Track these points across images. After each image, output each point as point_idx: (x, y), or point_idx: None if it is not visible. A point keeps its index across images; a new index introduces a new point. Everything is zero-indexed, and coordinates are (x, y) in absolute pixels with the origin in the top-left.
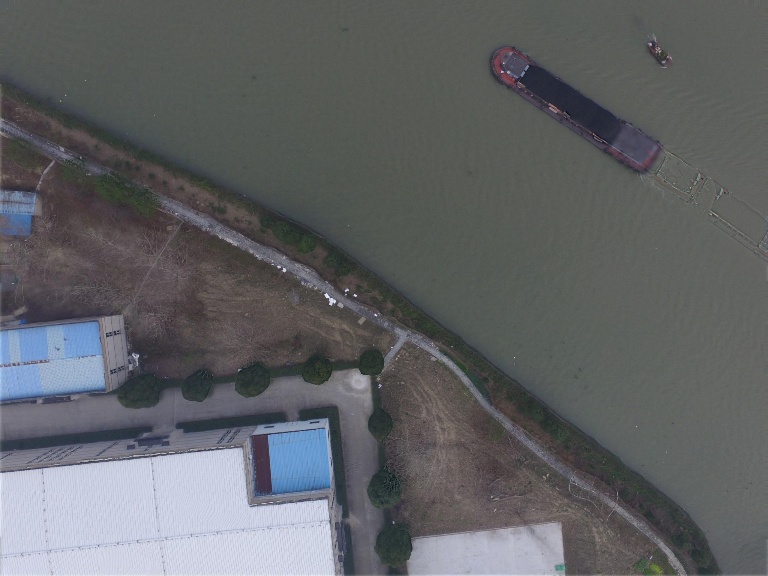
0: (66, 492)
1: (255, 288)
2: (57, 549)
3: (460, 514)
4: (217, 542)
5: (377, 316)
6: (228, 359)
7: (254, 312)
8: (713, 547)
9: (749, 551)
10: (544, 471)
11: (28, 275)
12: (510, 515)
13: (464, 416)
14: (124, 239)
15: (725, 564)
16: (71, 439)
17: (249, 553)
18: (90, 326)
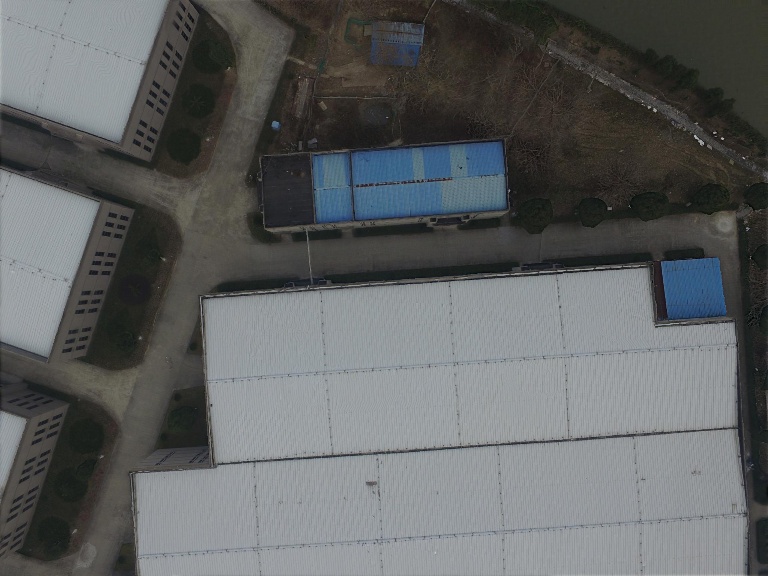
0: (472, 306)
1: (630, 125)
2: (463, 362)
3: None
4: (622, 361)
5: (745, 159)
6: (597, 197)
7: (629, 148)
8: None
9: None
10: None
11: (405, 108)
12: None
13: None
14: None
15: None
16: (441, 271)
17: (652, 375)
18: (492, 146)
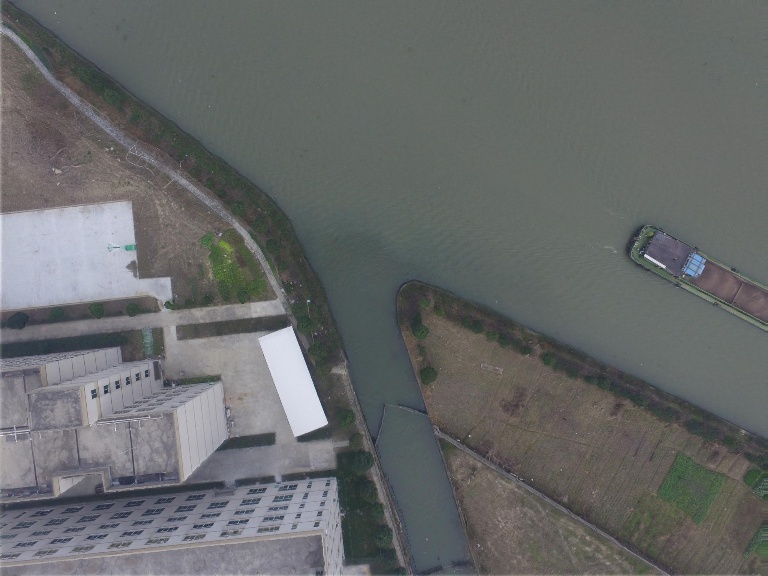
0: None
1: None
2: None
3: (20, 186)
4: None
5: None
6: None
7: None
8: (304, 237)
9: (342, 242)
10: (109, 145)
11: None
12: (72, 188)
13: (20, 84)
14: None
15: (314, 253)
16: None
17: None
18: None
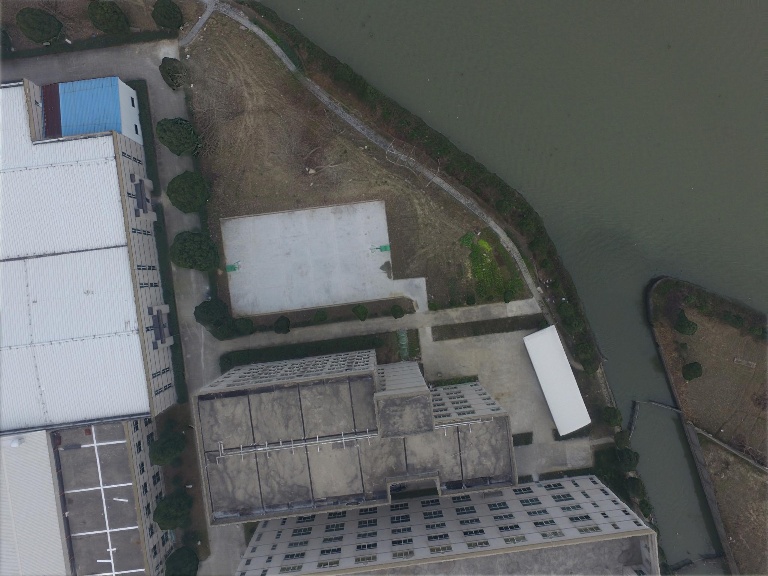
0: None
1: None
2: None
3: (274, 187)
4: (1, 182)
5: None
6: None
7: None
8: (553, 235)
9: (592, 238)
10: (362, 143)
11: None
12: (327, 188)
13: (273, 81)
14: None
15: (565, 250)
16: None
17: (34, 194)
18: None
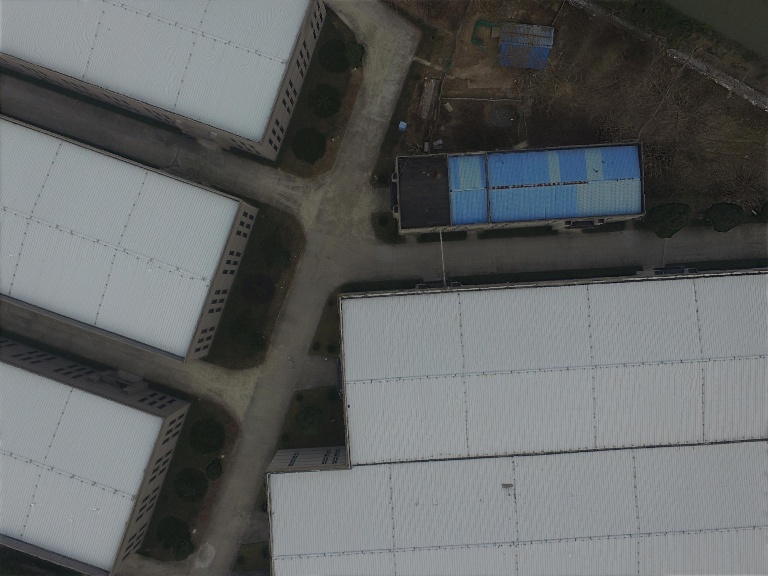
0: (610, 309)
1: (756, 131)
2: (601, 365)
3: None
4: (758, 366)
5: None
6: None
7: (755, 154)
8: None
9: None
10: None
11: (531, 111)
12: None
13: None
14: (632, 77)
15: None
16: (565, 274)
17: None
18: (627, 150)
